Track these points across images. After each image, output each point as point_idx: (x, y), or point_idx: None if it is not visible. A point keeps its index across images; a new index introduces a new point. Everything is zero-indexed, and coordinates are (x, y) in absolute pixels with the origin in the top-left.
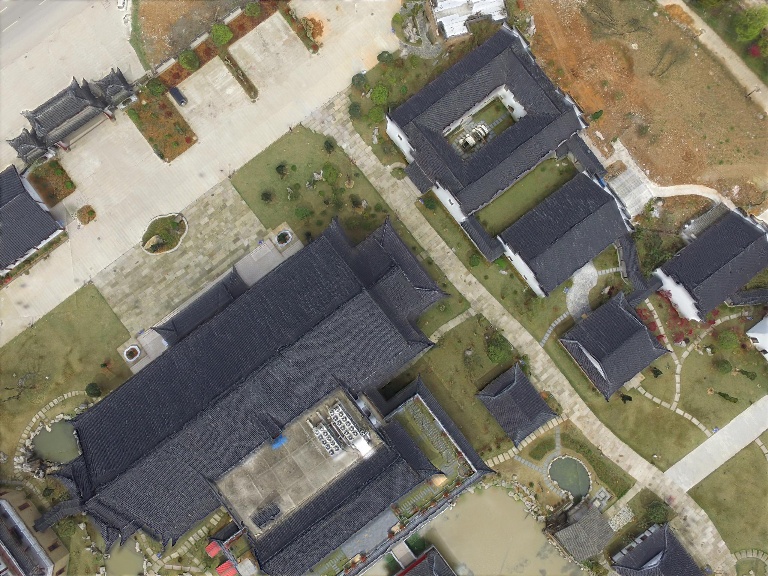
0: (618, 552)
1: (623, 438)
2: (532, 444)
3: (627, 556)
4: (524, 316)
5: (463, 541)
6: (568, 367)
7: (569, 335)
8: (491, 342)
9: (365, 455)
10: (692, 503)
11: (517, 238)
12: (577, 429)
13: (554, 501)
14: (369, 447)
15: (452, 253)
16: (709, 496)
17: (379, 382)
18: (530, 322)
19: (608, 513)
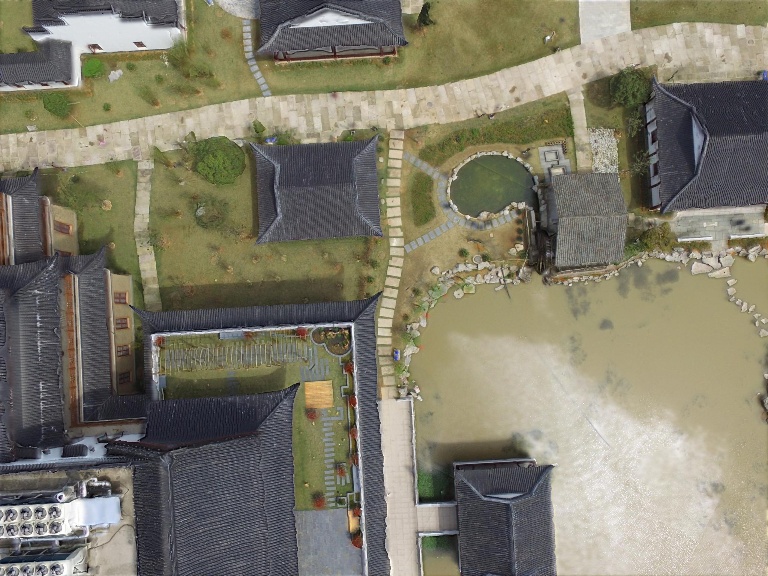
0: (650, 192)
1: (488, 68)
2: (404, 211)
3: (664, 179)
4: (205, 90)
5: (481, 413)
6: (327, 77)
7: (265, 33)
8: (196, 163)
9: (135, 513)
10: (653, 33)
11: (49, 5)
12: (428, 128)
13: (510, 236)
14: (112, 500)
15: (35, 134)
16: (660, 0)
17: (105, 384)
18: (220, 88)
19: (583, 166)
